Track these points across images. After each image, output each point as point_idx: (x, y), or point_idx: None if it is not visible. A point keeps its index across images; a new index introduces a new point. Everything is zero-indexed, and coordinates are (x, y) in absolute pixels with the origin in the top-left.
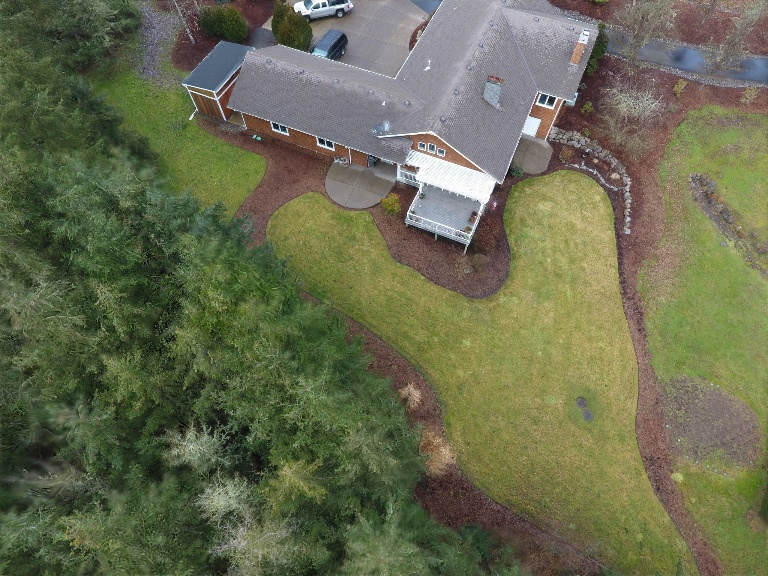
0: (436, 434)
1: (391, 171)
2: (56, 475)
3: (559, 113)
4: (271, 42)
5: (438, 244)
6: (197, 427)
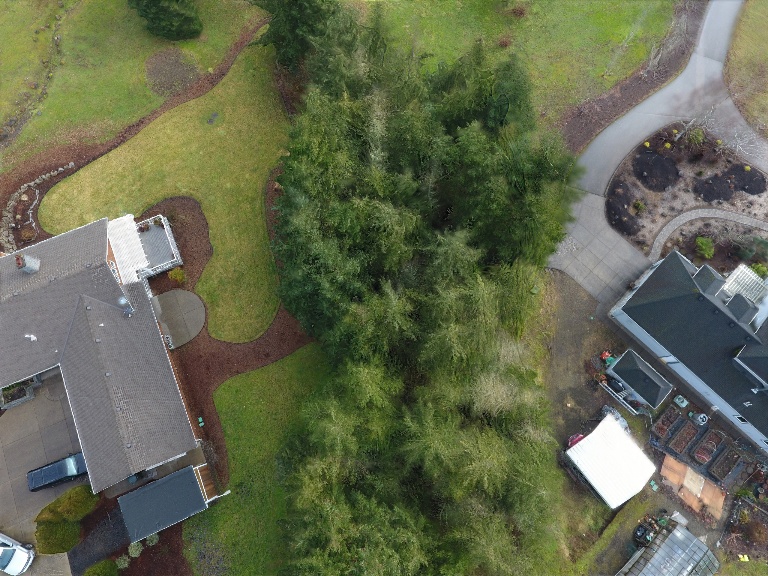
0: None
1: None
2: (448, 230)
3: None
4: (86, 543)
5: (179, 242)
6: (365, 144)
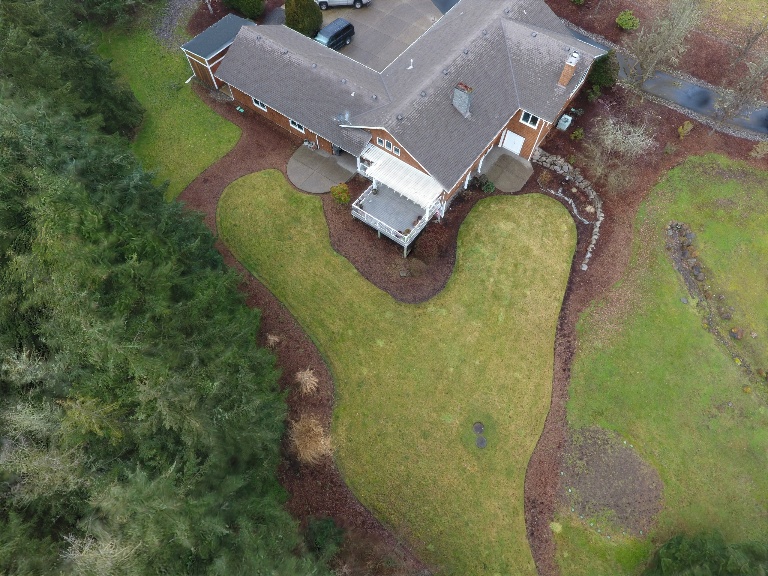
0: (322, 423)
1: (354, 162)
2: None
3: (548, 135)
4: (284, 22)
5: (381, 242)
6: (20, 348)
